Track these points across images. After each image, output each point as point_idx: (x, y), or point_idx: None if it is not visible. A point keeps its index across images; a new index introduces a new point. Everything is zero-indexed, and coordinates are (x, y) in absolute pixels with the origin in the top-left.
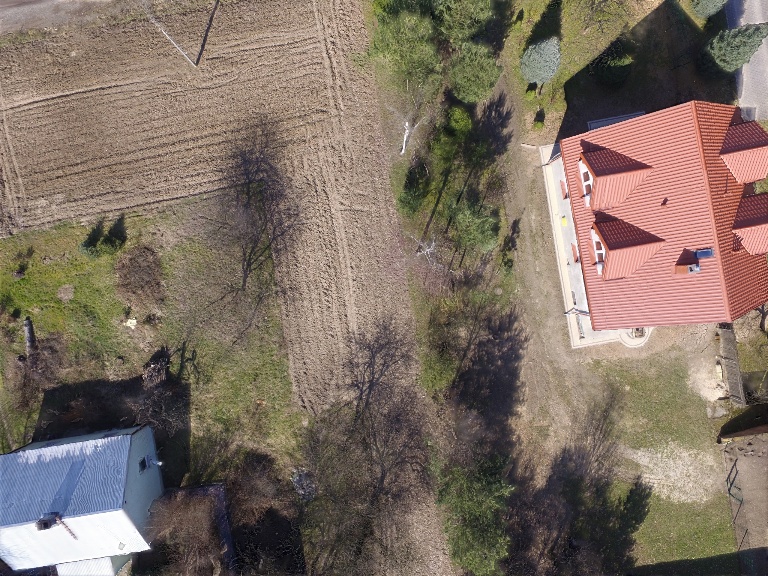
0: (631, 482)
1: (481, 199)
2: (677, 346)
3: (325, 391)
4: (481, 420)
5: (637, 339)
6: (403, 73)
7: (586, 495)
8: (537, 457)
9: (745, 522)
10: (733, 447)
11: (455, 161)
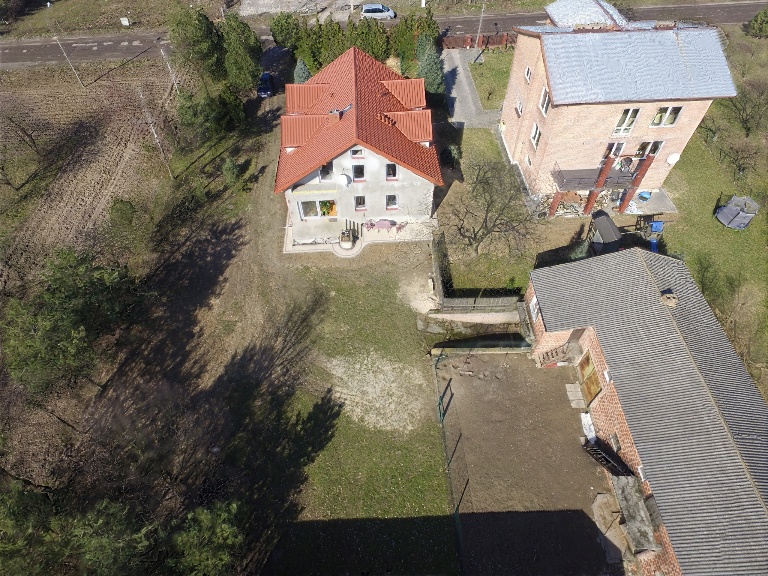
0: (318, 395)
1: (241, 153)
2: (390, 262)
3: (29, 270)
4: (167, 307)
5: (349, 251)
6: (185, 51)
7: (256, 403)
8: (213, 352)
9: (465, 468)
10: (447, 364)
11: (230, 134)
